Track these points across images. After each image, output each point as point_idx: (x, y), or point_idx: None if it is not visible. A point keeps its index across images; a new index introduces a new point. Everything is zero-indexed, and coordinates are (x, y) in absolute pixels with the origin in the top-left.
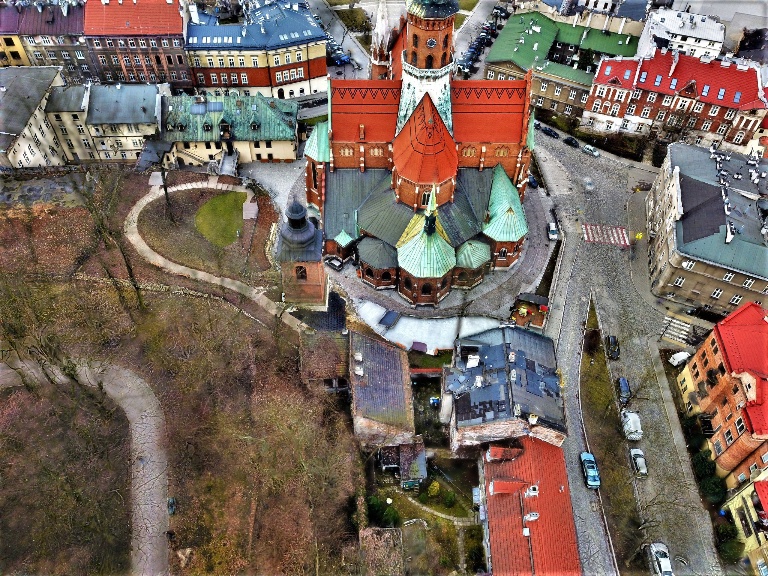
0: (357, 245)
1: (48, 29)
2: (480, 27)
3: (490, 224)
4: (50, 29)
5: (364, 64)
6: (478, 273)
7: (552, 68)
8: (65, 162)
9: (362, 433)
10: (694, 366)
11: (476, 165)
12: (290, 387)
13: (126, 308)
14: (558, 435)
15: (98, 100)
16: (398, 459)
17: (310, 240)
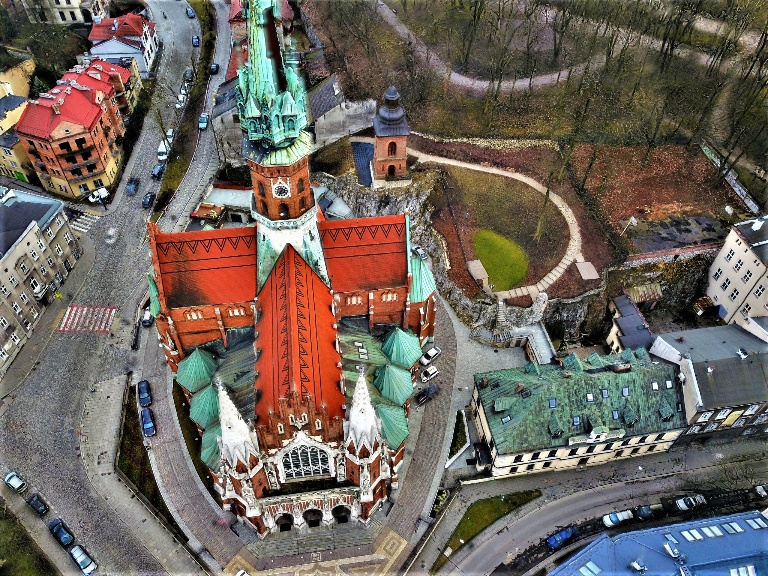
0: None
1: None
2: None
3: None
4: None
5: None
6: None
7: None
8: None
9: None
10: None
11: None
12: (379, 107)
13: None
14: None
15: (751, 342)
16: None
17: None
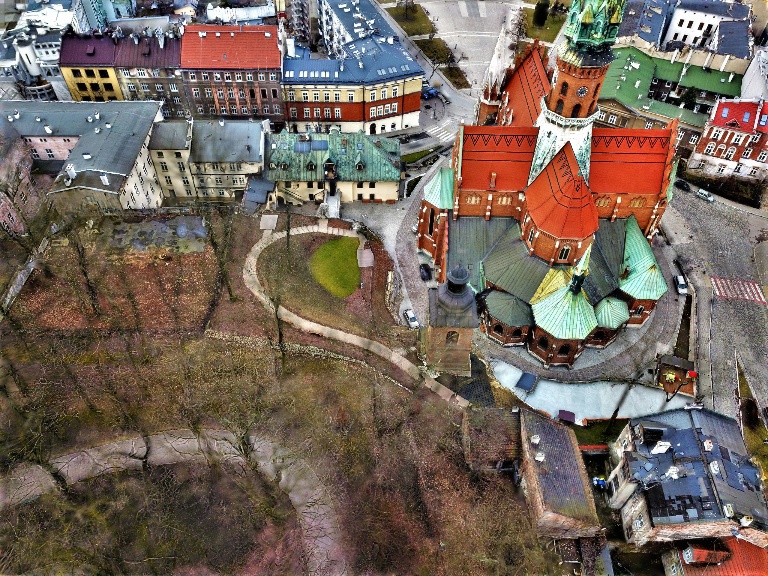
0: (485, 299)
1: (144, 61)
2: None
3: (628, 280)
4: (146, 61)
5: (452, 98)
6: (614, 332)
7: (658, 107)
8: (162, 199)
9: (543, 526)
10: None
11: (607, 215)
12: (454, 468)
13: (278, 377)
14: (767, 537)
15: (201, 137)
16: (579, 554)
17: (469, 305)
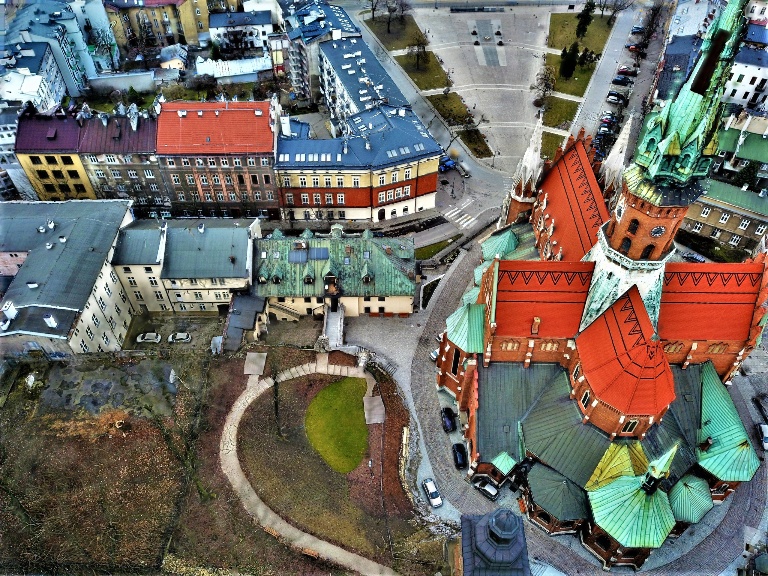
0: (527, 477)
1: (114, 146)
2: (597, 118)
3: (710, 455)
4: (116, 146)
5: (472, 170)
6: None
7: (716, 190)
8: (131, 316)
9: None
10: None
11: (678, 361)
12: None
13: None
14: None
15: (176, 247)
16: None
17: None
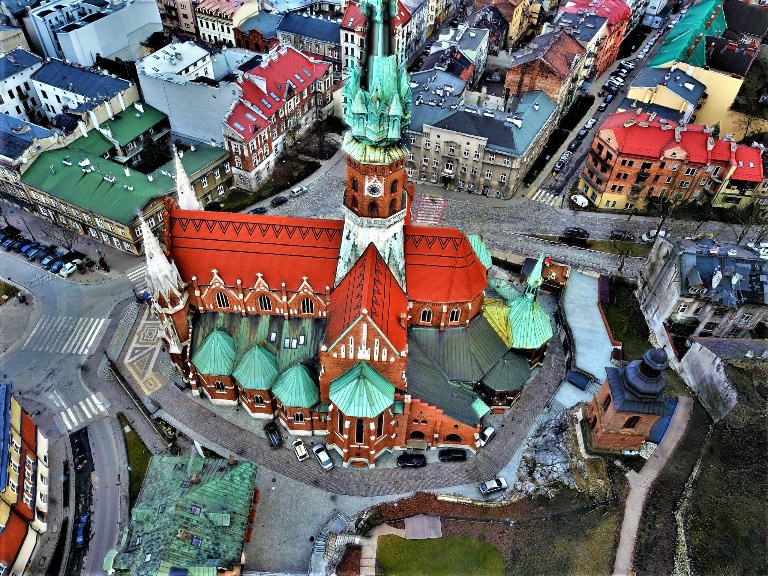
0: None
1: None
2: None
3: None
4: None
5: None
6: None
7: None
8: None
9: None
10: (613, 187)
11: None
12: (767, 435)
13: None
14: None
15: None
16: None
17: None
